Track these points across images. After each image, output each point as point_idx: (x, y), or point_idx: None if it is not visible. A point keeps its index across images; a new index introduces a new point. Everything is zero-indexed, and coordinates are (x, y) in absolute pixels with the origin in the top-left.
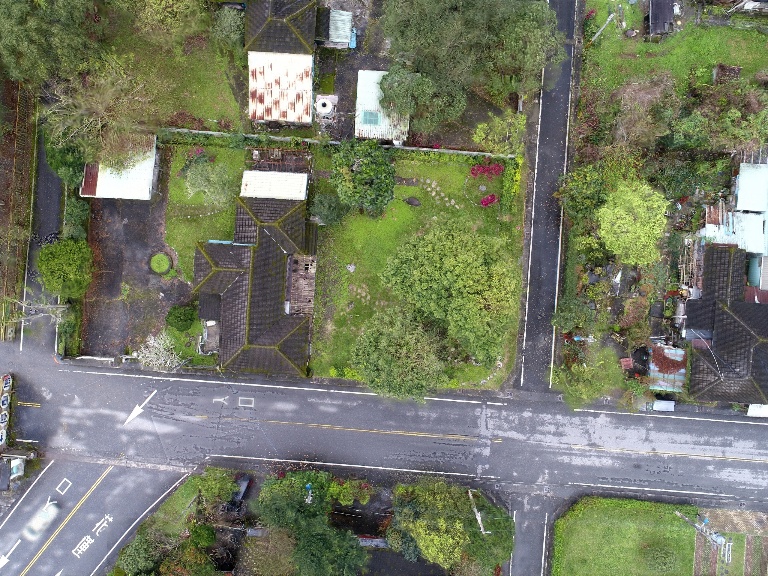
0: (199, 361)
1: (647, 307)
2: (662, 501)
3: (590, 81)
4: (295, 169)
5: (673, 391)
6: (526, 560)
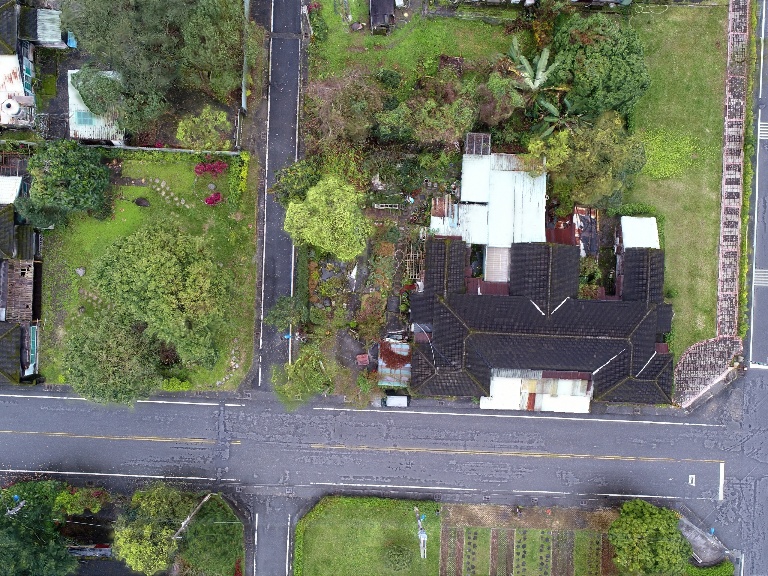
0: None
1: (383, 302)
2: (405, 498)
3: (318, 75)
4: (20, 172)
5: (401, 386)
6: (270, 563)
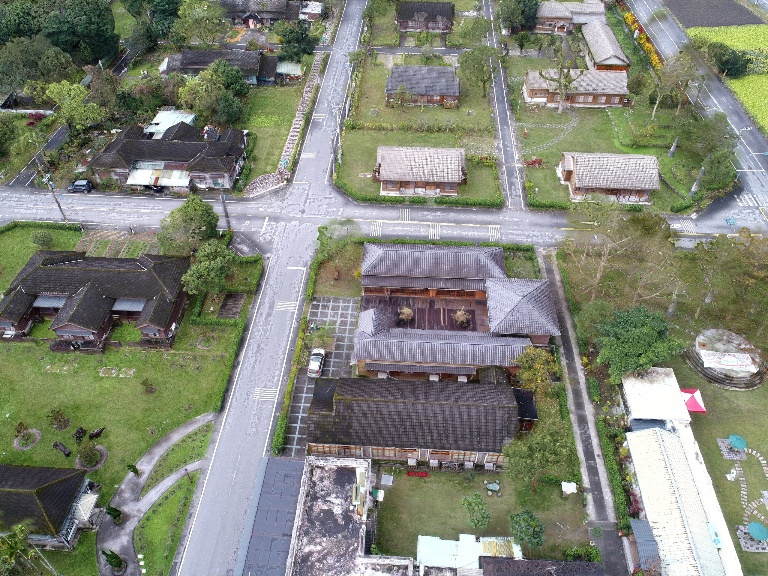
0: None
1: None
2: None
3: None
4: None
5: (84, 172)
6: None
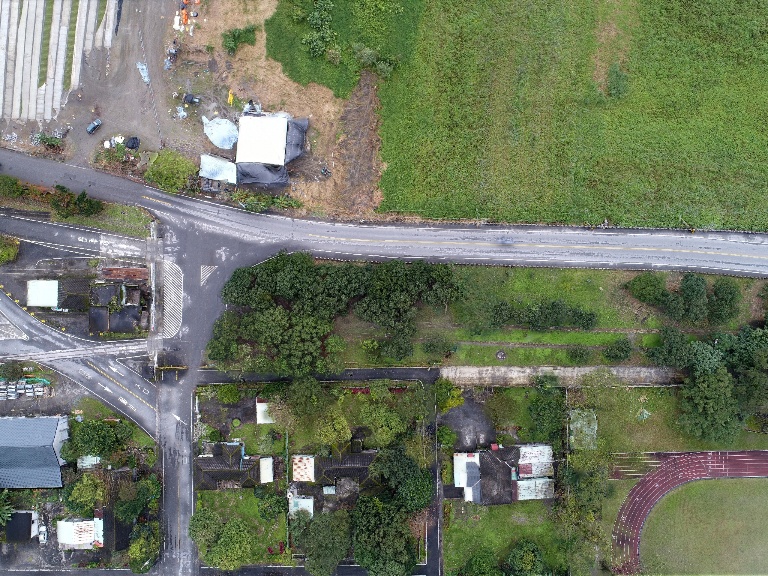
0: (200, 441)
1: None
2: None
3: None
4: (278, 472)
5: None
6: (133, 575)
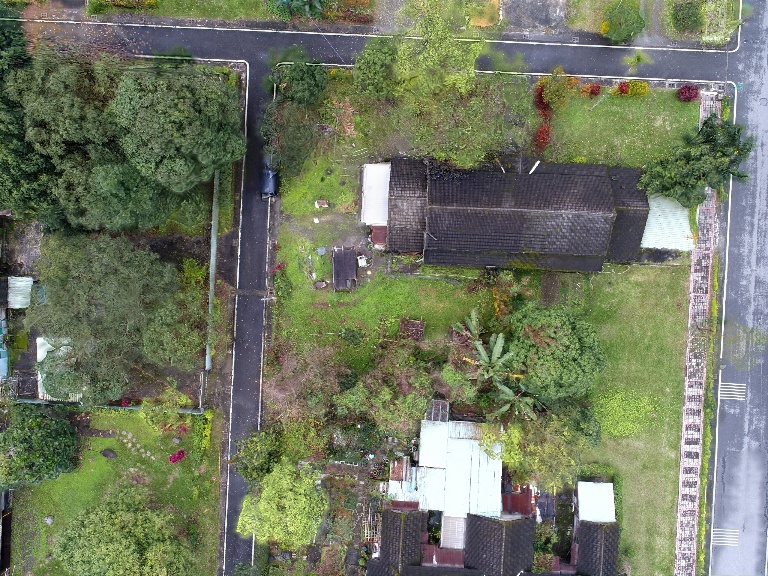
0: None
1: None
2: None
3: (282, 332)
4: None
5: None
6: None
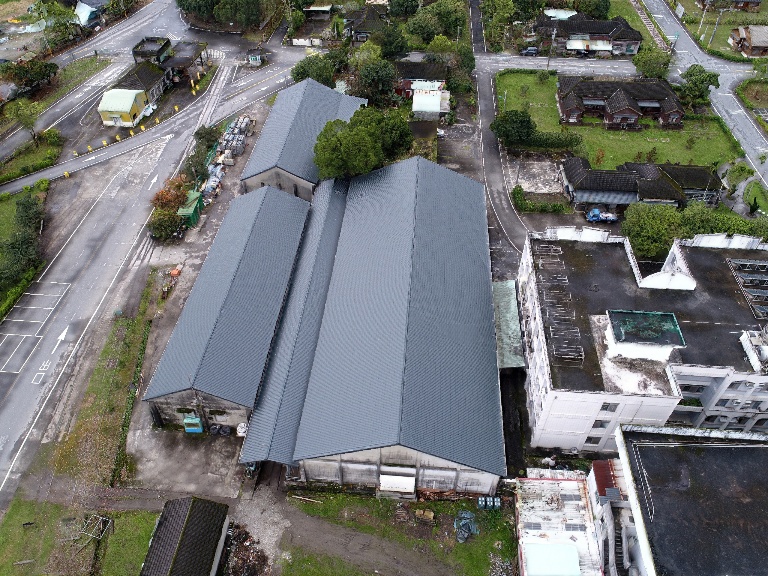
0: None
1: None
2: None
3: None
4: None
5: (533, 41)
6: None
